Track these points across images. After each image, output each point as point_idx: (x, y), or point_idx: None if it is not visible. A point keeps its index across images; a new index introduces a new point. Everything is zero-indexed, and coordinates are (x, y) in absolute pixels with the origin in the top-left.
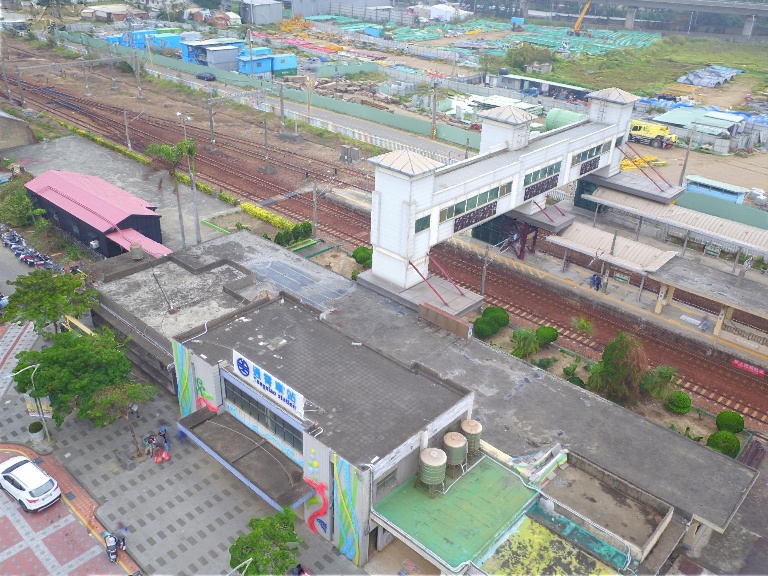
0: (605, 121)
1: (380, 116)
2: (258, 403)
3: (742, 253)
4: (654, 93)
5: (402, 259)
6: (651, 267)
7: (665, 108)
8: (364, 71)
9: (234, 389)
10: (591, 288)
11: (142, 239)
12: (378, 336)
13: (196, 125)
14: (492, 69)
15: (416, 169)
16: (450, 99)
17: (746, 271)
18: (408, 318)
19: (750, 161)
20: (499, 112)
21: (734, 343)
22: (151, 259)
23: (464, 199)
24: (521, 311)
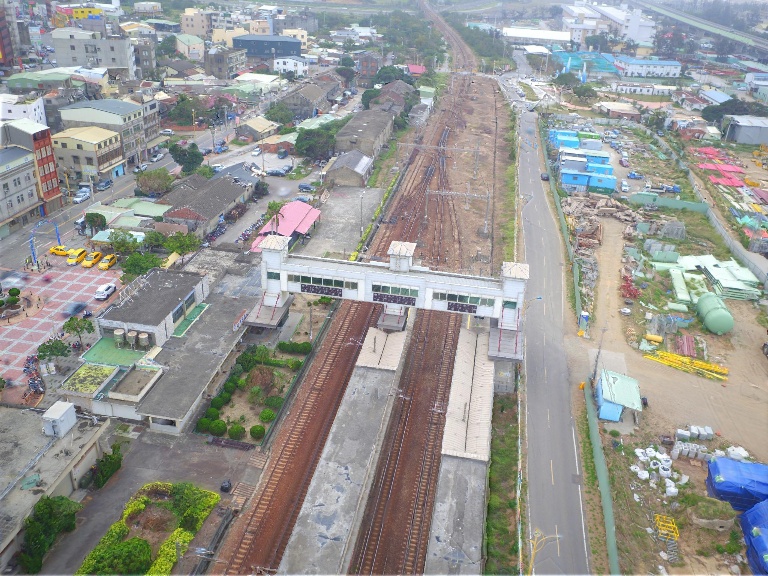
0: None
1: None
2: None
3: (518, 427)
4: None
5: None
6: (361, 363)
7: None
8: (686, 209)
9: None
10: None
11: None
12: (223, 313)
13: (457, 205)
14: None
15: (263, 245)
16: (676, 253)
17: None
18: None
19: None
20: None
21: None
22: (244, 250)
23: (309, 276)
24: None
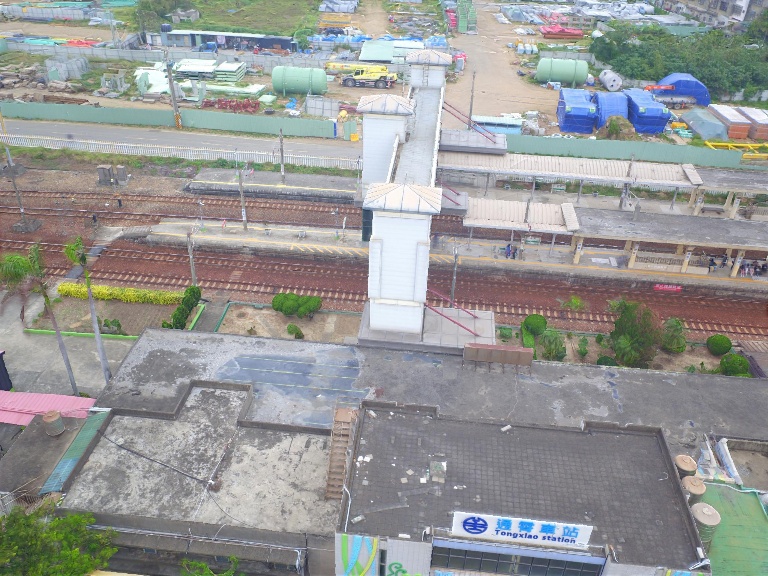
0: (429, 85)
1: (95, 114)
2: (501, 555)
3: (561, 181)
4: (318, 28)
5: (416, 304)
6: (572, 225)
7: (349, 44)
8: None
9: (450, 553)
10: (508, 258)
11: (13, 398)
12: (451, 400)
13: None
14: (151, 27)
15: (434, 205)
16: (146, 74)
17: (584, 198)
18: (450, 365)
19: (463, 86)
20: (382, 104)
21: (647, 270)
22: (75, 423)
23: None
24: (472, 305)
